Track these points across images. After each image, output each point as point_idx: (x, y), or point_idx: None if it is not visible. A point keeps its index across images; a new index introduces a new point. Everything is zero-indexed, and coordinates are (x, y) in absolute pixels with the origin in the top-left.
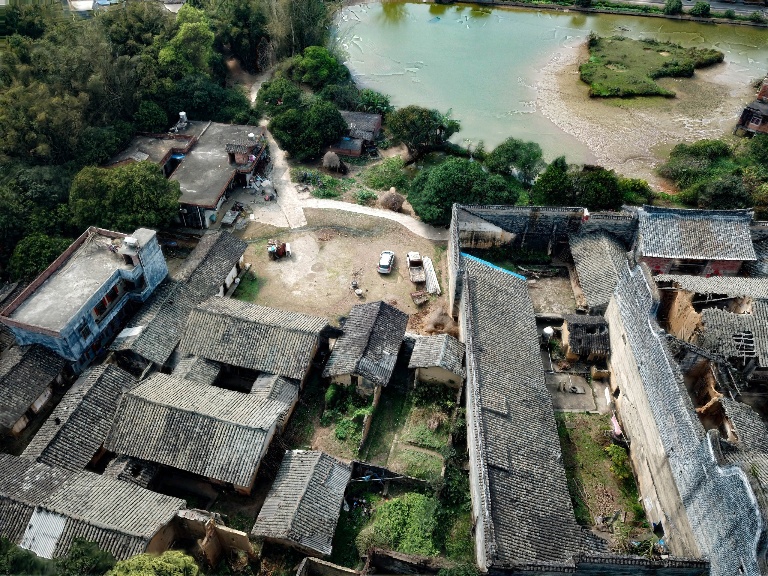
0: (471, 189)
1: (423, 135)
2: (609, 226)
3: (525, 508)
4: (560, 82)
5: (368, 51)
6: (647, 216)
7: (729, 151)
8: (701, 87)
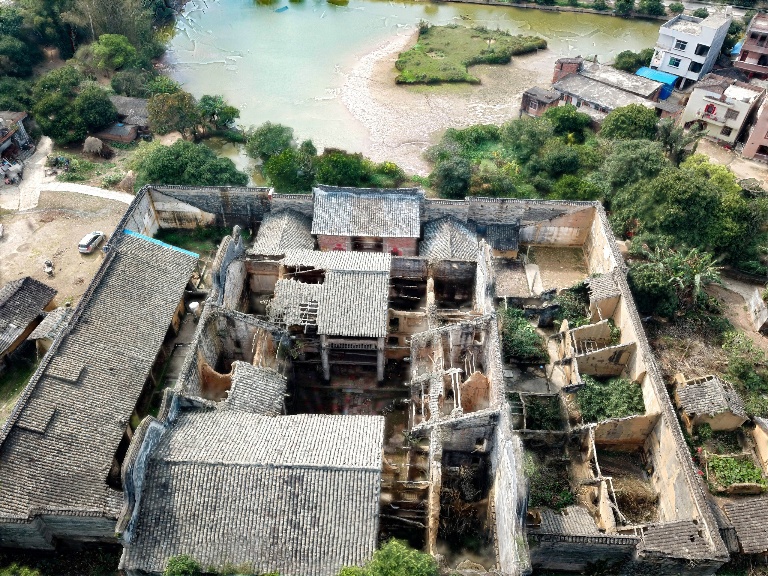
0: (184, 171)
1: (187, 120)
2: (294, 205)
3: (45, 467)
4: (375, 69)
5: (196, 40)
6: (323, 195)
7: (496, 135)
8: (512, 74)
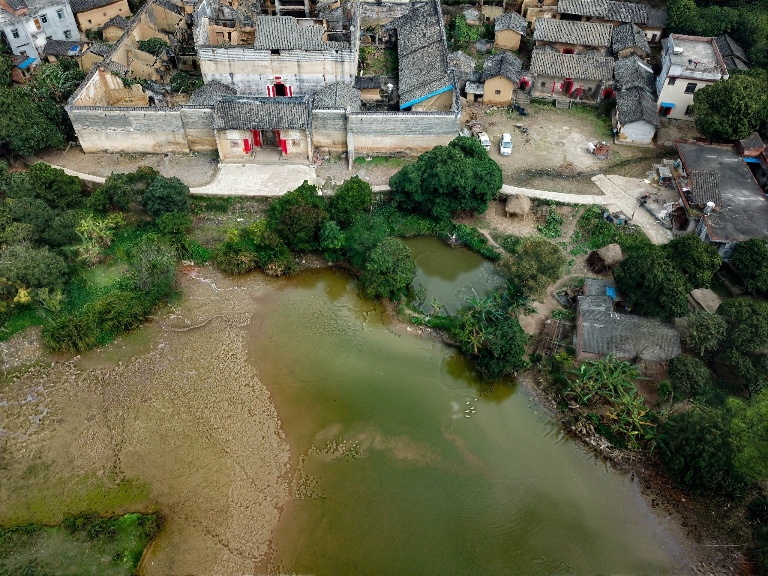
0: None
1: None
2: None
3: None
4: None
5: None
6: None
7: None
8: None
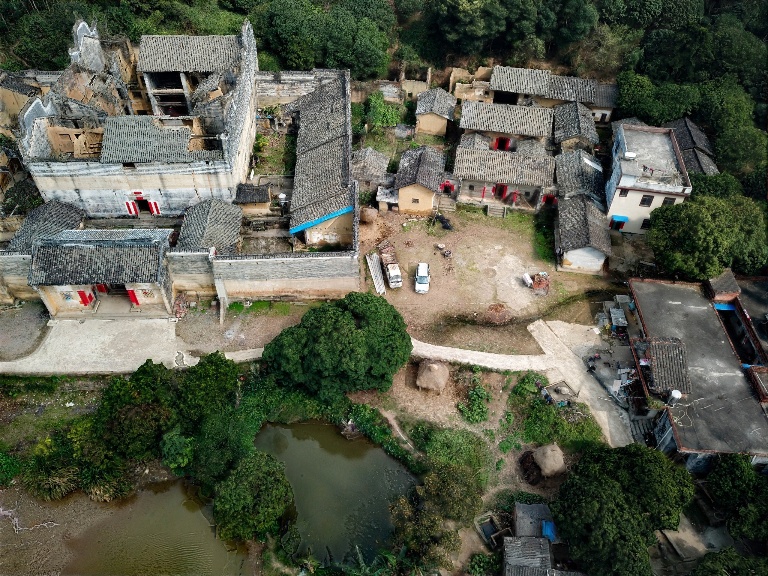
0: None
1: None
2: None
3: None
4: None
5: None
6: None
7: None
8: None
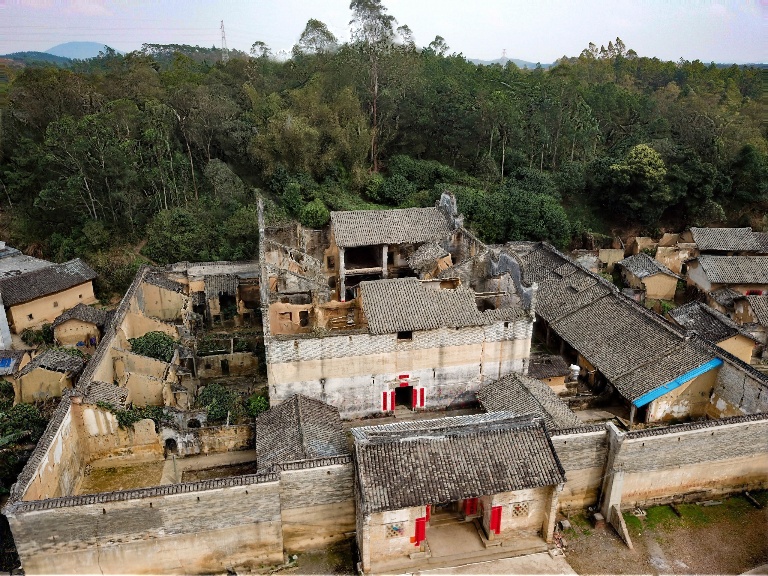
0: None
1: None
2: None
3: None
4: None
5: None
6: None
7: None
8: None
